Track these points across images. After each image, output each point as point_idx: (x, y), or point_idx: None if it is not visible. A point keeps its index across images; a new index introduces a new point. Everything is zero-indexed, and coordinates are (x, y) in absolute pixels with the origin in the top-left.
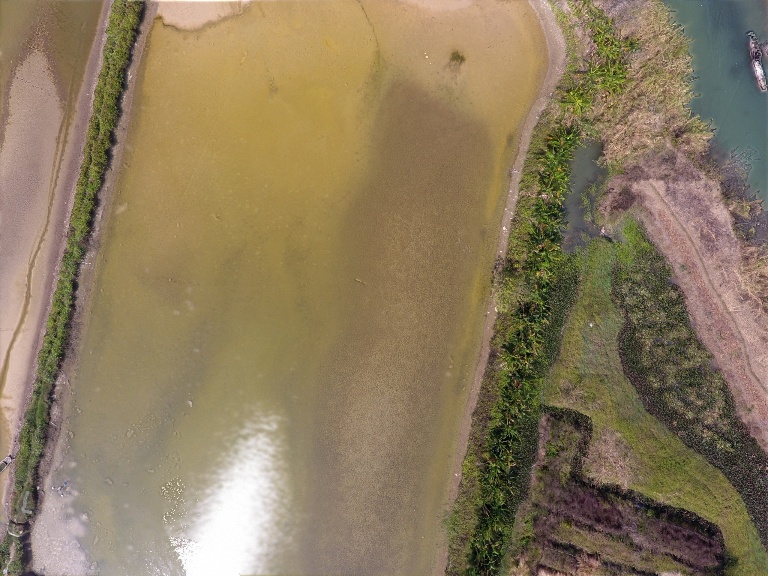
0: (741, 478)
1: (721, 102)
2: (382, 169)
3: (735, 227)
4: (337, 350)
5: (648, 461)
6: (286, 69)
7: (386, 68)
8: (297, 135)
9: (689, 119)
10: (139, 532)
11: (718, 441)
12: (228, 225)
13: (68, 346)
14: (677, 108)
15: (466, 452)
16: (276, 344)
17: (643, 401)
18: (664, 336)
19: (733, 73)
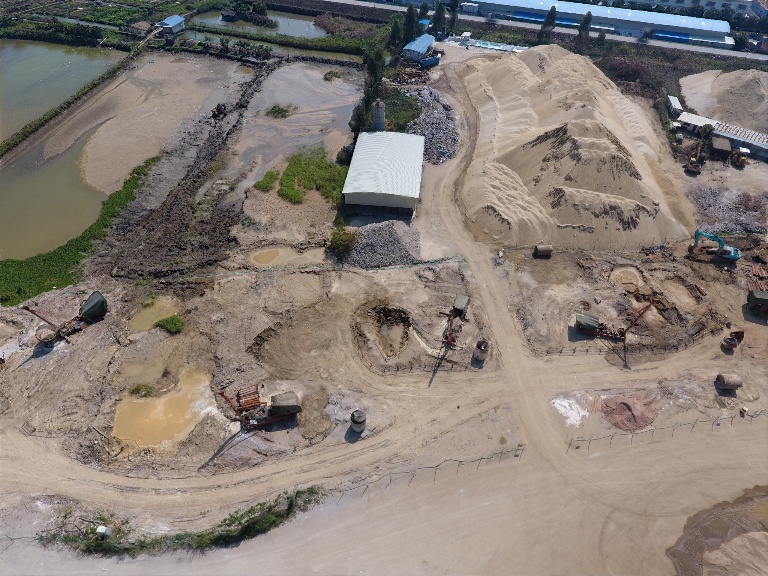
0: None
1: None
2: None
3: None
4: None
5: None
6: None
7: None
8: None
9: None
10: (84, 59)
11: None
12: None
13: None
14: None
15: None
16: None
17: None
18: None
19: None
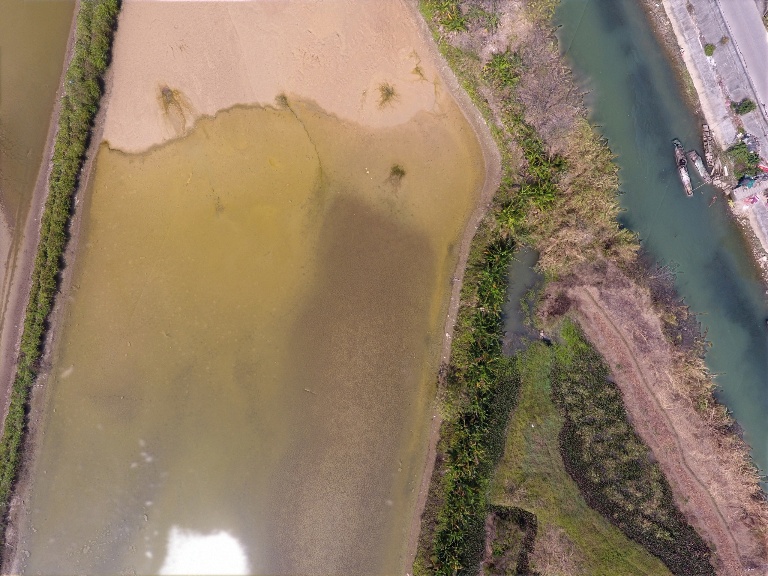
0: (680, 565)
1: (650, 207)
2: (327, 282)
3: (665, 331)
4: (288, 459)
5: (591, 554)
6: (231, 188)
7: (329, 184)
8: (243, 252)
9: (617, 232)
10: None
11: (657, 531)
12: (178, 342)
13: (22, 468)
14: (605, 223)
15: (416, 553)
16: (228, 455)
17: (585, 496)
18: (603, 432)
19: (661, 179)
